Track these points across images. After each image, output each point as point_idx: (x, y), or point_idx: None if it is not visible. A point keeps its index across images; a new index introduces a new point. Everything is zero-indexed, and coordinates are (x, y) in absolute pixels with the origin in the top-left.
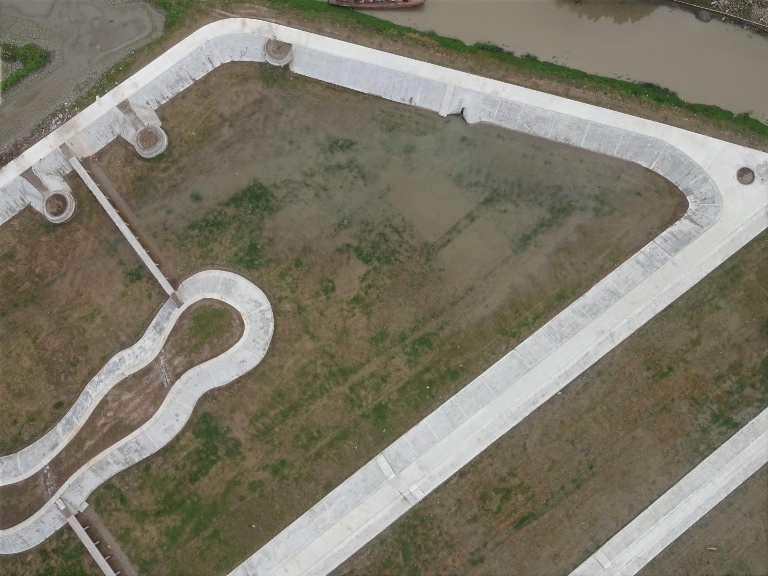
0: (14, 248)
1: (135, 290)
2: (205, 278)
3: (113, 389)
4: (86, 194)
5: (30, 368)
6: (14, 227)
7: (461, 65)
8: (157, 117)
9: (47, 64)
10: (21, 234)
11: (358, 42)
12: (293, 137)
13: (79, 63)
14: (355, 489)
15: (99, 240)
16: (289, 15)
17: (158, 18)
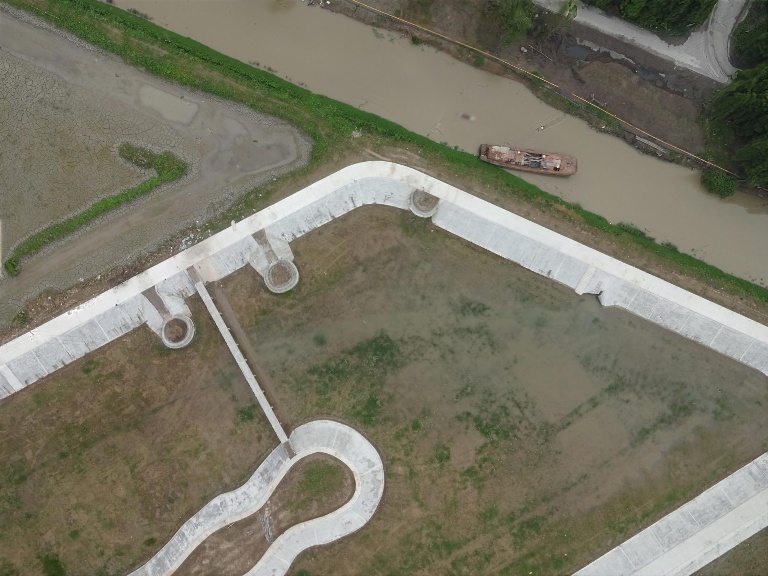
0: (123, 367)
1: (245, 430)
2: (320, 429)
3: (212, 536)
4: (206, 320)
5: (125, 498)
6: (126, 344)
7: (605, 247)
8: (290, 250)
9: (183, 176)
10: (132, 353)
11: (506, 207)
12: (426, 292)
13: (216, 180)
14: None
15: (214, 371)
16: (440, 167)
17: (304, 146)
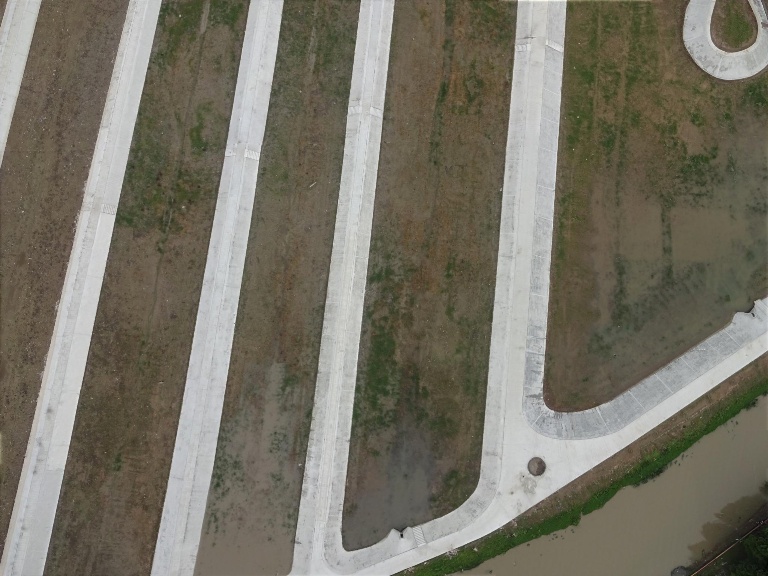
0: None
1: None
2: (766, 55)
3: None
4: None
5: None
6: None
7: None
8: None
9: None
10: None
11: None
12: None
13: None
14: (557, 18)
15: None
16: None
17: None
